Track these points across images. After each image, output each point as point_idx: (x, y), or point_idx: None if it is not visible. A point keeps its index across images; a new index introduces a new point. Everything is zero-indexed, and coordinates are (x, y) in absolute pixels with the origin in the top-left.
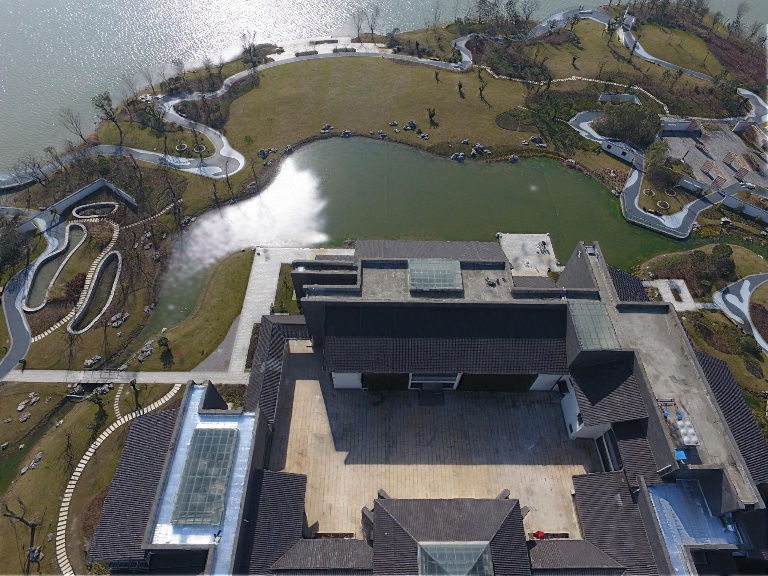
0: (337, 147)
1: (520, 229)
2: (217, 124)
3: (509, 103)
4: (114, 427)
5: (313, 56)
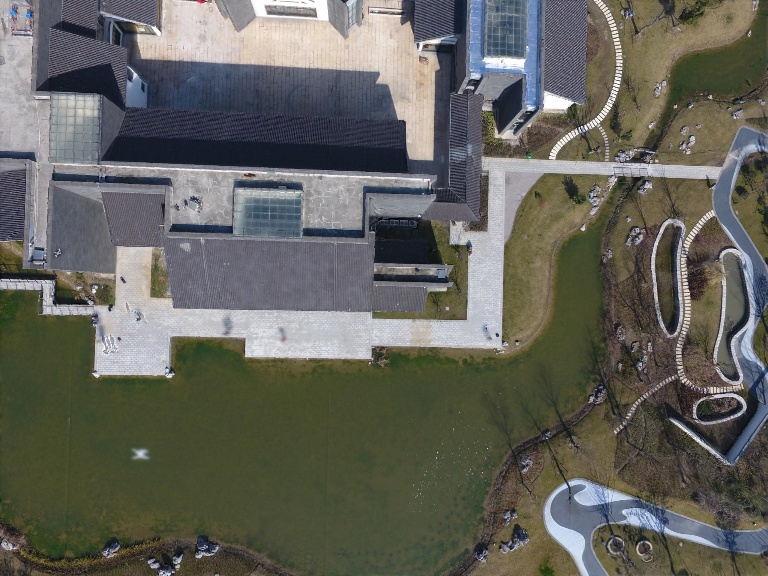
0: (406, 568)
1: (135, 388)
2: None
3: None
4: (601, 116)
5: None
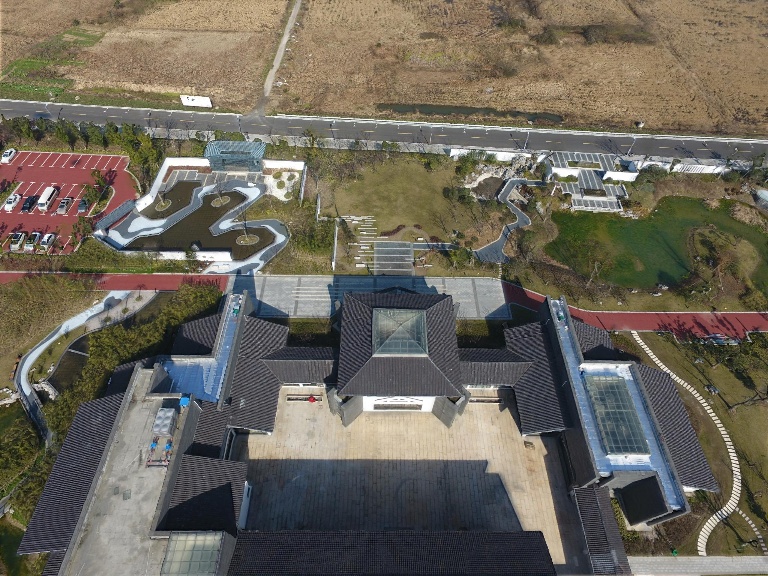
0: None
1: None
2: None
3: None
4: (734, 498)
5: None
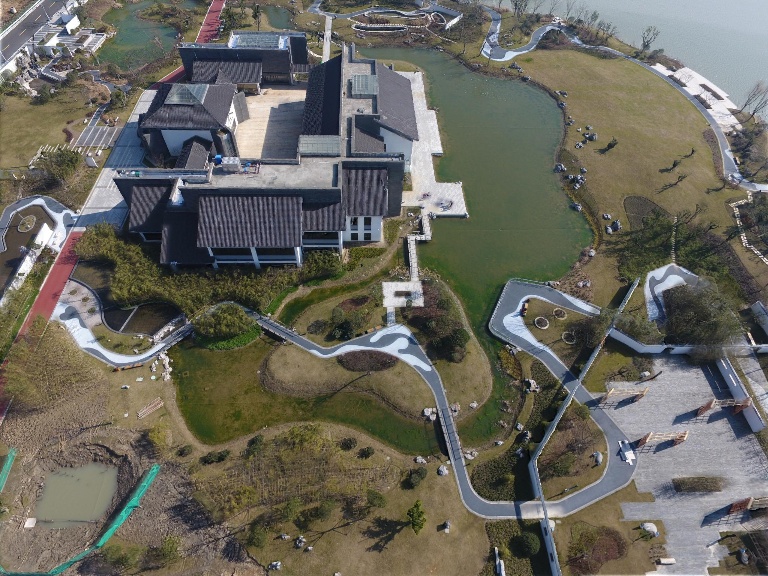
0: (543, 102)
1: (472, 200)
2: (539, 45)
3: (677, 209)
4: None
5: (676, 84)
